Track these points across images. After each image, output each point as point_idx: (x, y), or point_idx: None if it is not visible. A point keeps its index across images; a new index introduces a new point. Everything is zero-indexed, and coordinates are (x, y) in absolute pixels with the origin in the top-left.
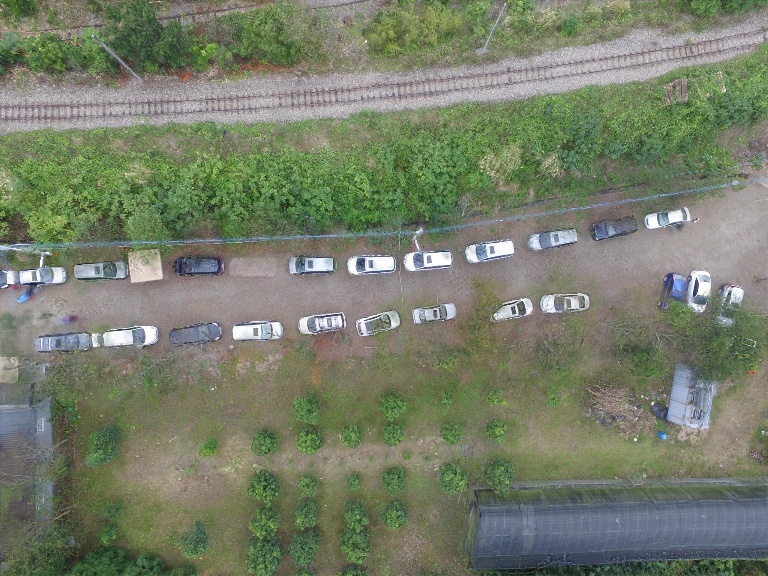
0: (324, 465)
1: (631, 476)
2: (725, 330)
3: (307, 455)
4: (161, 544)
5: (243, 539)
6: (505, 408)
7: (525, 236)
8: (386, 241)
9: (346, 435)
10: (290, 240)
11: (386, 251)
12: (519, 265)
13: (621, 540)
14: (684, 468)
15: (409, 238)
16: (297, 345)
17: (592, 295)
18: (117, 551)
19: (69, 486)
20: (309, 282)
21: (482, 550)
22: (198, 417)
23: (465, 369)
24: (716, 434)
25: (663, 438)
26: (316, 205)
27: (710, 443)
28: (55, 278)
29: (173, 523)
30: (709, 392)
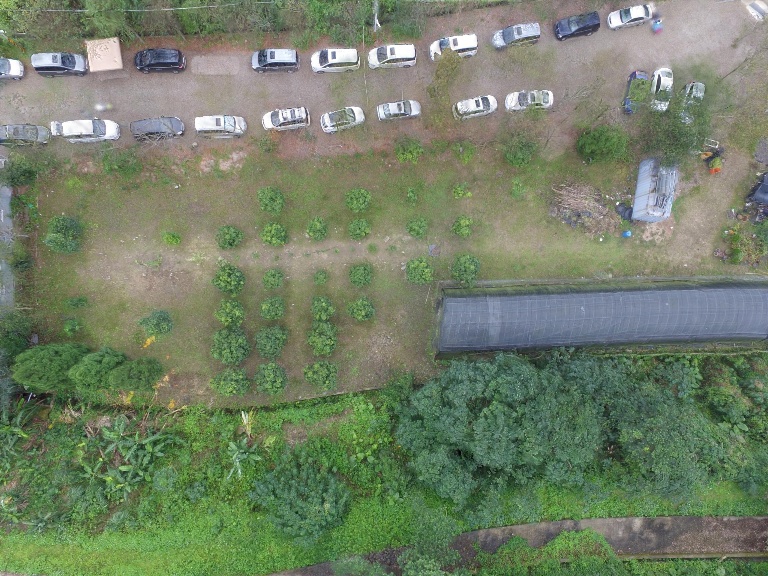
0: (290, 262)
1: (597, 274)
2: (688, 129)
3: (273, 251)
4: (127, 343)
5: (210, 338)
6: (471, 208)
7: (489, 36)
8: (349, 36)
9: (311, 224)
10: (253, 38)
11: (350, 48)
12: (484, 65)
13: (586, 328)
14: (649, 268)
15: (373, 36)
16: None
17: (557, 96)
18: (81, 344)
19: (31, 284)
20: (273, 80)
21: (449, 339)
22: (162, 215)
23: (431, 169)
24: (680, 234)
25: (628, 235)
26: None
27: (674, 243)
28: (12, 69)
29: None
30: (671, 175)
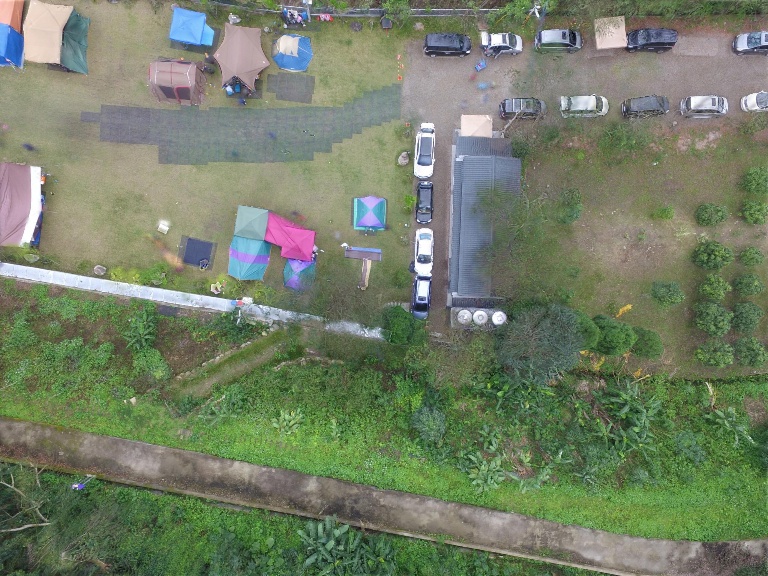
0: (761, 241)
1: None
2: None
3: (746, 230)
4: (600, 312)
5: (677, 311)
6: None
7: None
8: None
9: None
10: (733, 20)
11: None
12: None
13: None
14: None
15: None
16: (736, 124)
17: None
18: None
19: (517, 252)
20: (749, 63)
21: None
22: (639, 191)
23: None
24: None
25: None
26: None
27: None
28: (518, 45)
29: (612, 292)
30: None
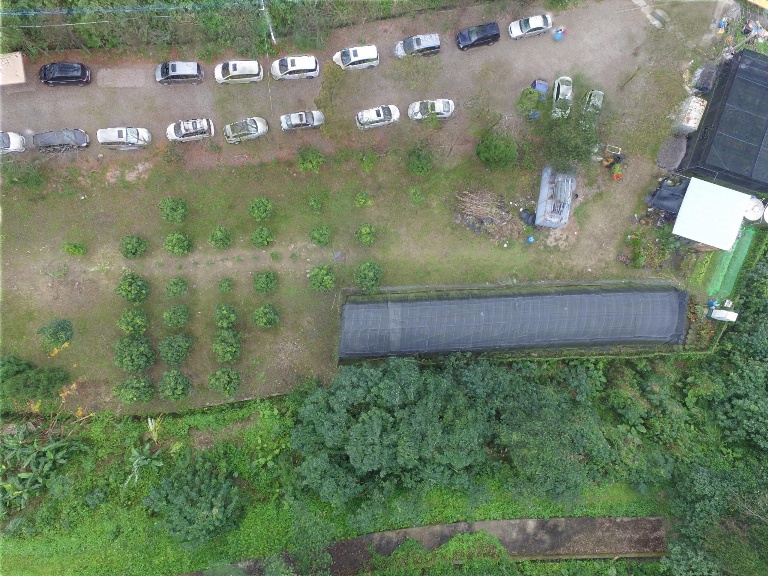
0: (195, 270)
1: (501, 279)
2: (589, 136)
3: (178, 260)
4: (34, 352)
5: None
6: (376, 216)
7: (392, 47)
8: (252, 48)
9: (212, 233)
10: (158, 51)
11: (253, 60)
12: (387, 75)
13: (486, 333)
14: (553, 273)
15: None
16: None
17: (460, 105)
18: None
19: None
20: (178, 92)
21: (350, 345)
22: (69, 226)
23: (336, 178)
24: (584, 239)
25: (530, 240)
26: (173, 1)
27: (578, 248)
28: None
29: None
30: (565, 182)
